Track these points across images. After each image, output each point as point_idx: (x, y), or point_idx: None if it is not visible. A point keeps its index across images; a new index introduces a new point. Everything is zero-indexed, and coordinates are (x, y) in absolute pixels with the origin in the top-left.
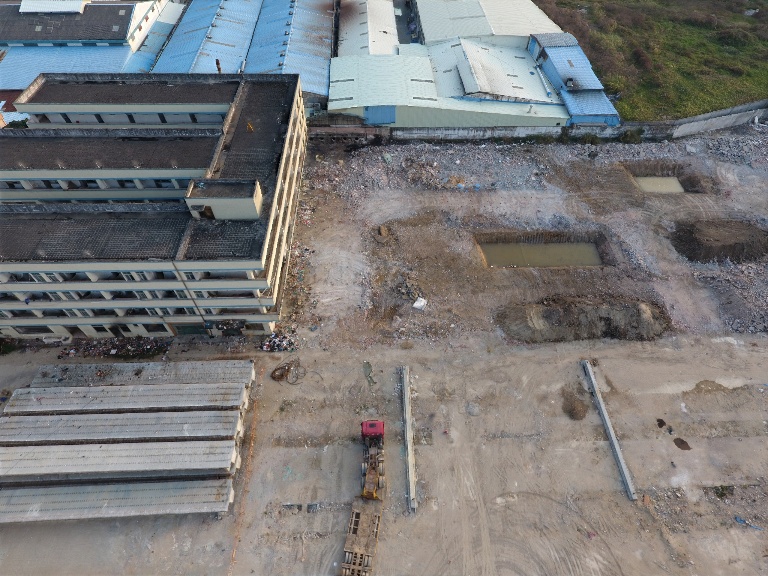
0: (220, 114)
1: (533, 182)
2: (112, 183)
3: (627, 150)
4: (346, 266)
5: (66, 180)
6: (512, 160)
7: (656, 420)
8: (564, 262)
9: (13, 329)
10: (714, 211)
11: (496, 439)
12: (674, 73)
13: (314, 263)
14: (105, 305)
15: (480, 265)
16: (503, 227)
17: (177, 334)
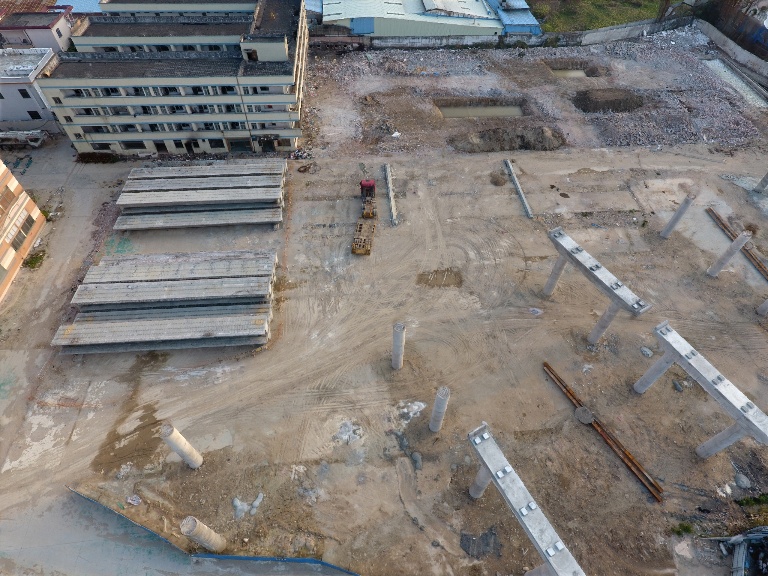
0: (248, 13)
1: (477, 70)
2: (180, 50)
3: (547, 51)
4: (343, 117)
5: (149, 46)
6: (462, 58)
7: (550, 185)
8: (497, 116)
9: (119, 145)
10: (605, 85)
11: (447, 195)
12: (589, 6)
13: (320, 116)
14: (186, 119)
15: (438, 116)
16: (454, 96)
17: (230, 151)
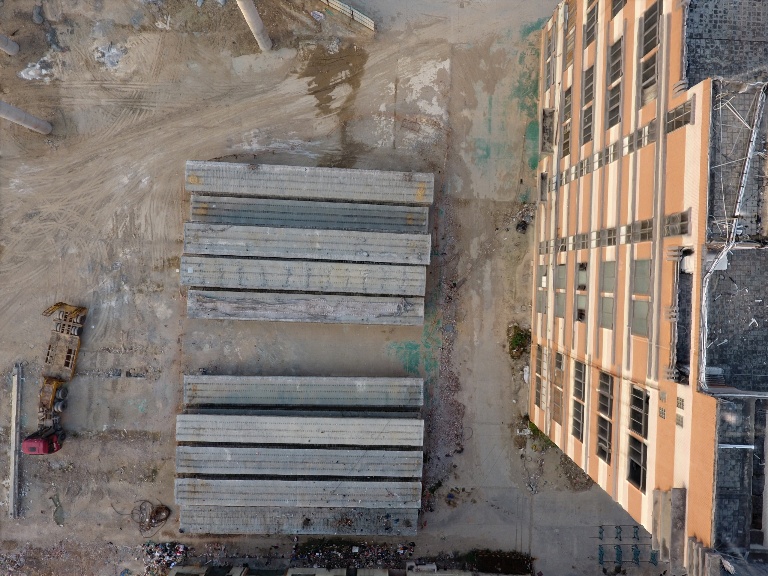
0: None
1: None
2: None
3: None
4: None
5: None
6: None
7: None
8: None
9: None
10: None
11: None
12: None
13: None
14: None
15: None
16: None
17: (286, 571)
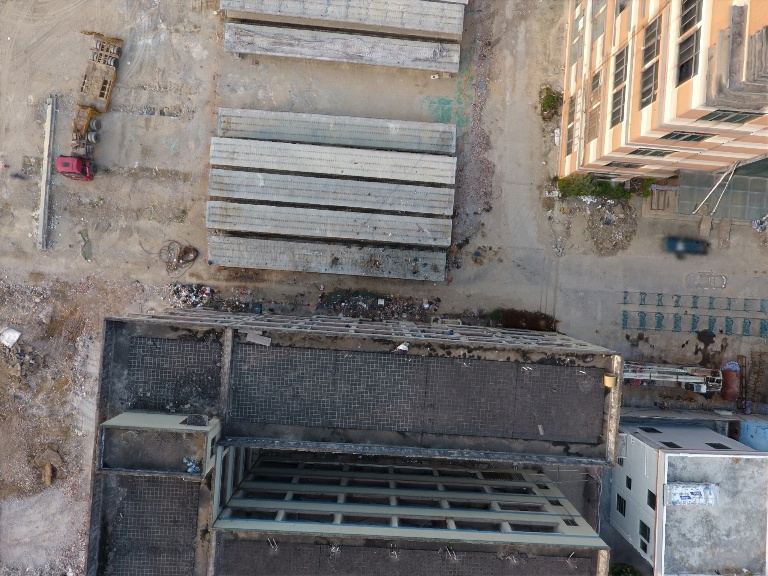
0: None
1: None
2: None
3: None
4: None
5: None
6: None
7: None
8: None
9: None
10: None
11: None
12: None
13: None
14: None
15: None
16: None
17: None
